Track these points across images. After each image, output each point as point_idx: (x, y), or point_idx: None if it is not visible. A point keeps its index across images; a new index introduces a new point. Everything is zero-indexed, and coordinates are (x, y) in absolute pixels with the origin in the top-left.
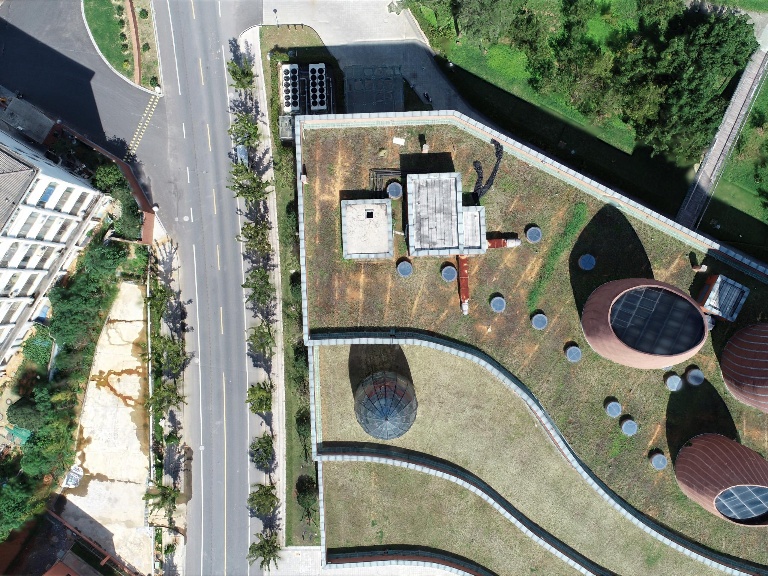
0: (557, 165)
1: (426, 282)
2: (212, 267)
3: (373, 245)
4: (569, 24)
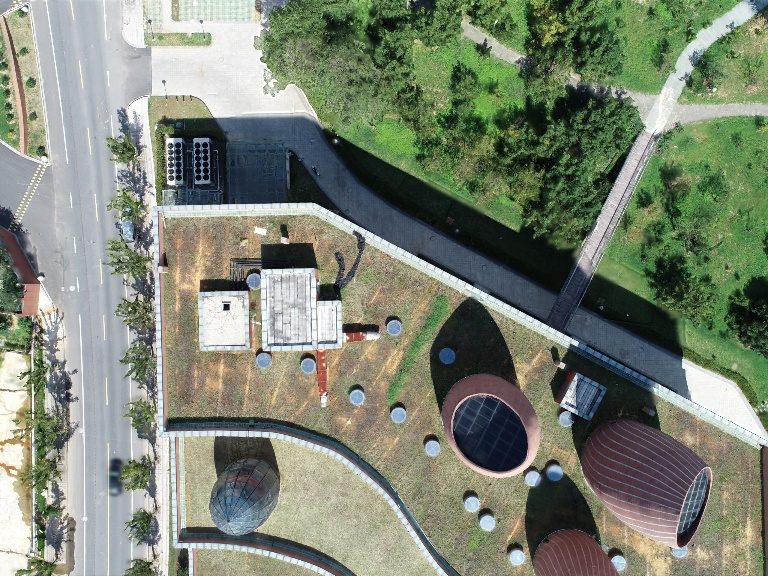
0: (416, 259)
1: (286, 373)
2: (98, 337)
3: (230, 337)
4: (457, 101)
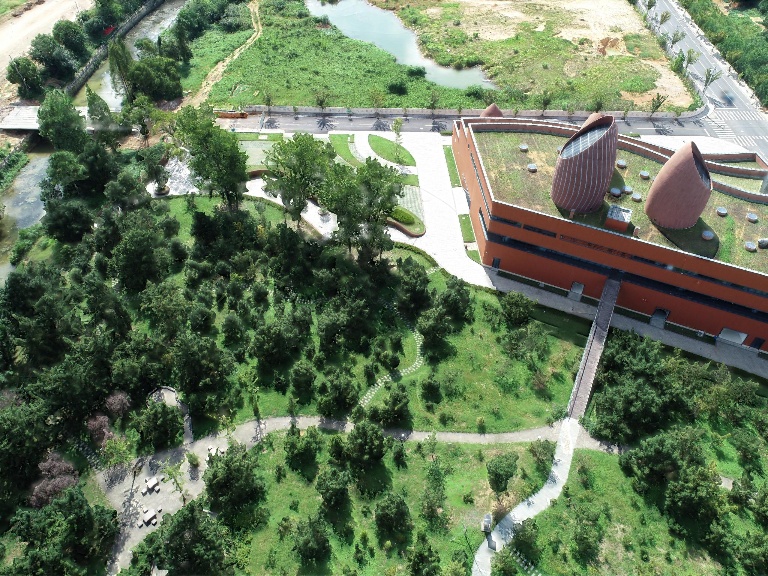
0: (761, 273)
1: None
2: None
3: None
4: None
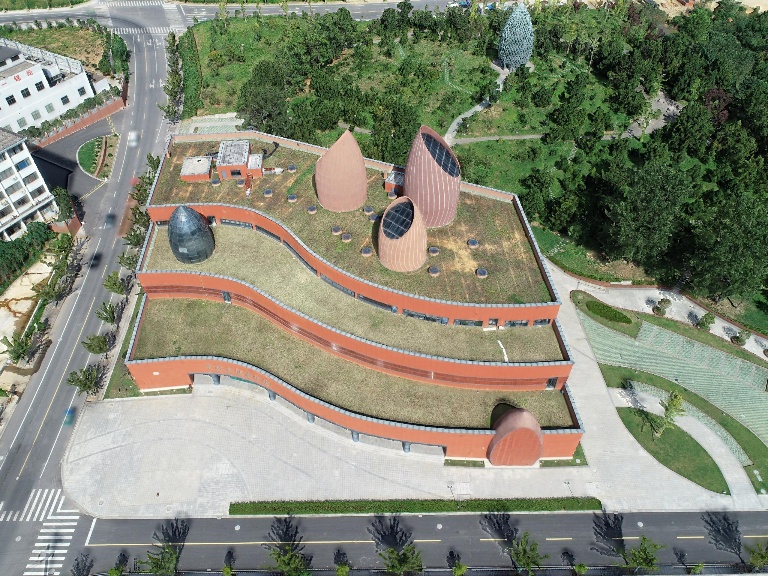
0: None
1: (228, 188)
2: (108, 247)
3: (198, 171)
4: None
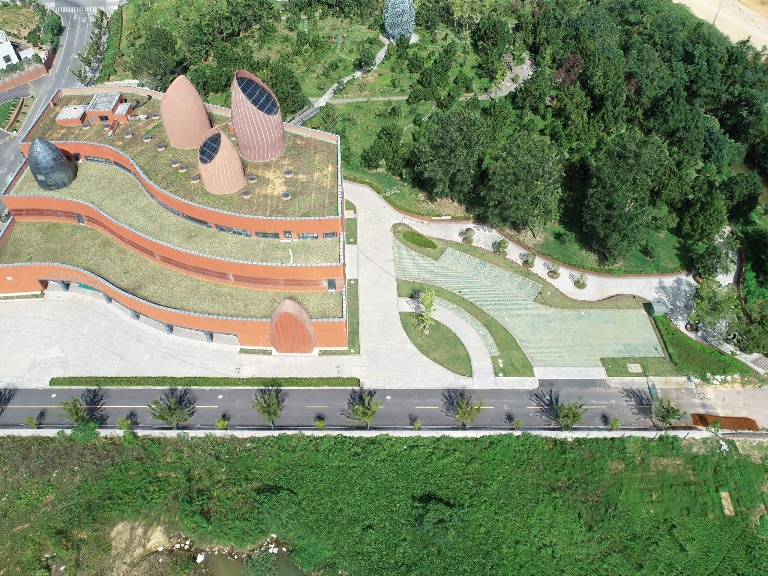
0: None
1: None
2: None
3: (72, 116)
4: None
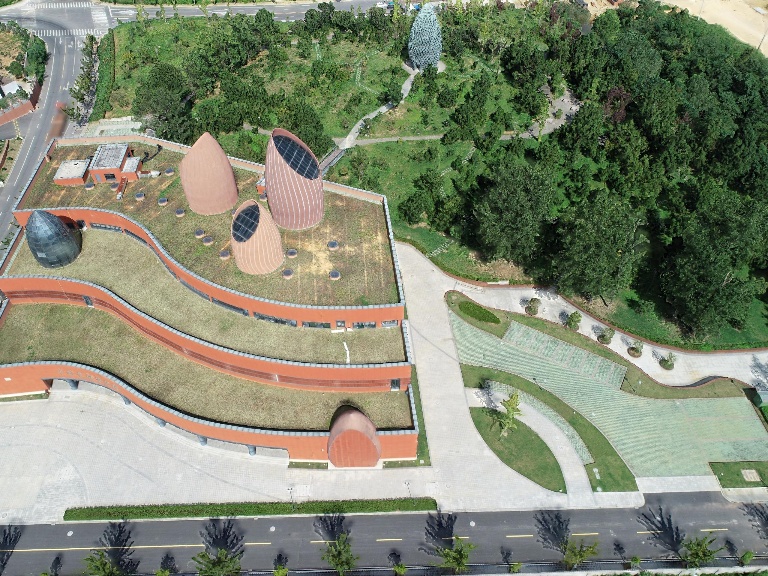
0: (186, 146)
1: (101, 192)
2: None
3: (73, 174)
4: None
